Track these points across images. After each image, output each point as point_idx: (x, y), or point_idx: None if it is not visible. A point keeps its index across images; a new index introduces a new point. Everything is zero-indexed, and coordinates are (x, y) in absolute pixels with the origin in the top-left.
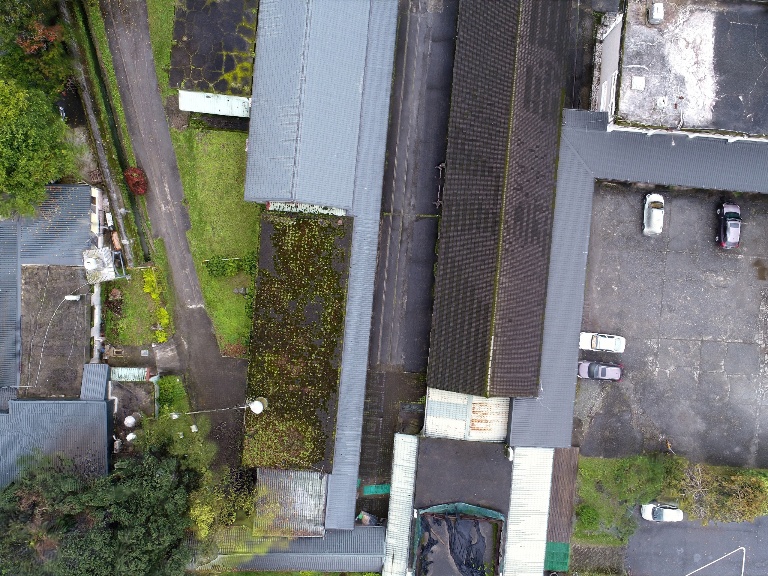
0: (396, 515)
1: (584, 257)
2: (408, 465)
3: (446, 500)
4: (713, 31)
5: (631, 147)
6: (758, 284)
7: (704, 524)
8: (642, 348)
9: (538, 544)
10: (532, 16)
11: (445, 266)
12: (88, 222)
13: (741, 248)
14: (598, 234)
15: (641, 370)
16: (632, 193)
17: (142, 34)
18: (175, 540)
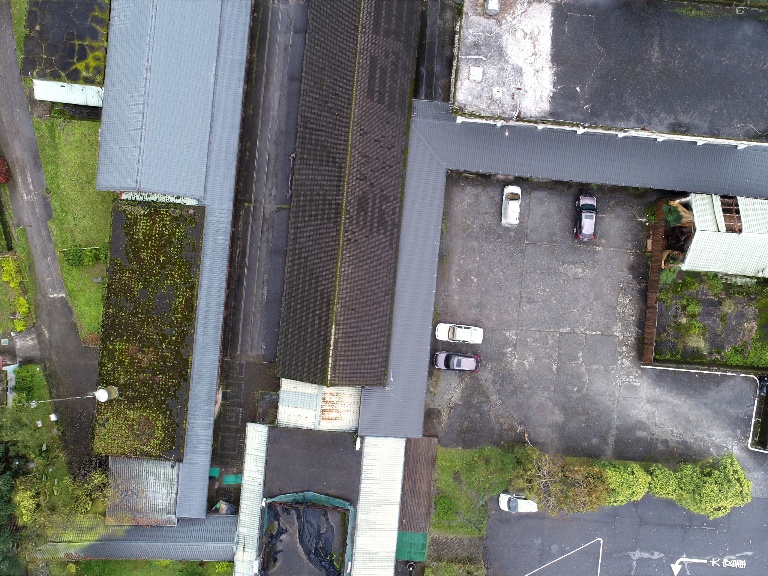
0: (247, 504)
1: (436, 248)
2: (259, 454)
3: (295, 489)
4: (551, 22)
5: (481, 138)
6: (616, 276)
7: (553, 514)
8: (501, 339)
9: (389, 534)
10: (376, 7)
11: (293, 256)
12: None
13: (599, 240)
14: (458, 225)
15: (500, 361)
16: (492, 185)
17: (5, 24)
18: None
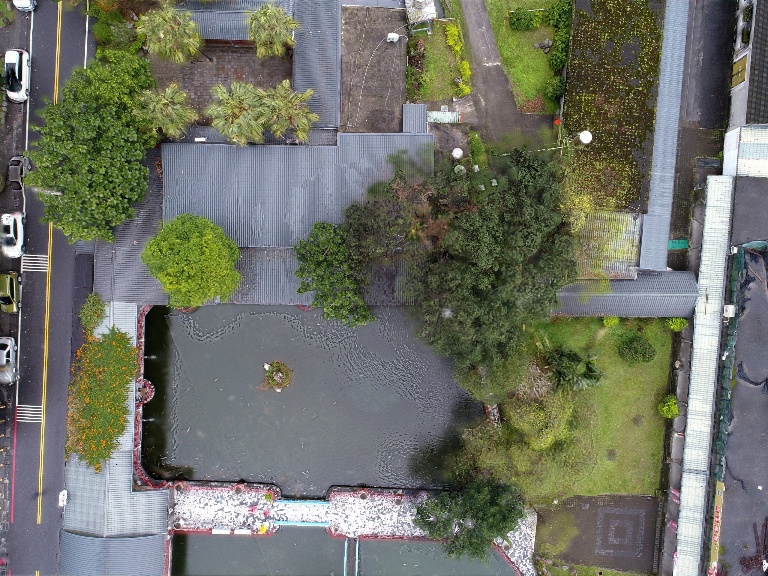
0: (710, 256)
1: None
2: (723, 205)
3: (763, 237)
4: None
5: None
6: None
7: None
8: None
9: None
10: None
11: (767, 2)
12: None
13: None
14: None
15: None
16: None
17: None
18: (556, 227)
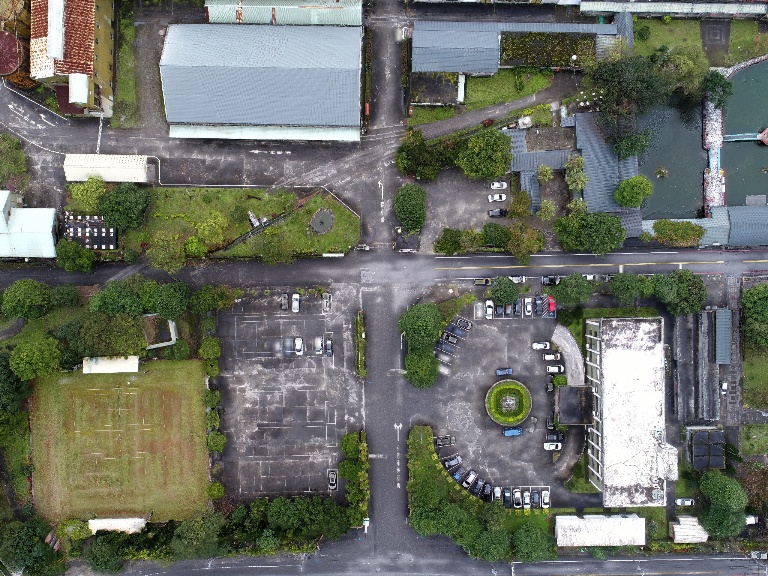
0: (611, 8)
1: None
2: (592, 5)
3: None
4: None
5: None
6: None
7: None
8: None
9: None
10: None
11: None
12: (509, 130)
13: None
14: None
15: None
16: None
17: (431, 125)
18: None
